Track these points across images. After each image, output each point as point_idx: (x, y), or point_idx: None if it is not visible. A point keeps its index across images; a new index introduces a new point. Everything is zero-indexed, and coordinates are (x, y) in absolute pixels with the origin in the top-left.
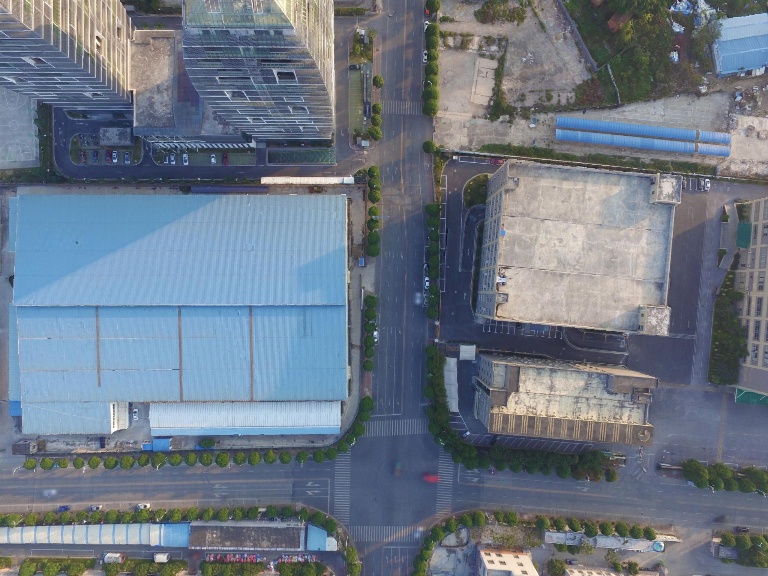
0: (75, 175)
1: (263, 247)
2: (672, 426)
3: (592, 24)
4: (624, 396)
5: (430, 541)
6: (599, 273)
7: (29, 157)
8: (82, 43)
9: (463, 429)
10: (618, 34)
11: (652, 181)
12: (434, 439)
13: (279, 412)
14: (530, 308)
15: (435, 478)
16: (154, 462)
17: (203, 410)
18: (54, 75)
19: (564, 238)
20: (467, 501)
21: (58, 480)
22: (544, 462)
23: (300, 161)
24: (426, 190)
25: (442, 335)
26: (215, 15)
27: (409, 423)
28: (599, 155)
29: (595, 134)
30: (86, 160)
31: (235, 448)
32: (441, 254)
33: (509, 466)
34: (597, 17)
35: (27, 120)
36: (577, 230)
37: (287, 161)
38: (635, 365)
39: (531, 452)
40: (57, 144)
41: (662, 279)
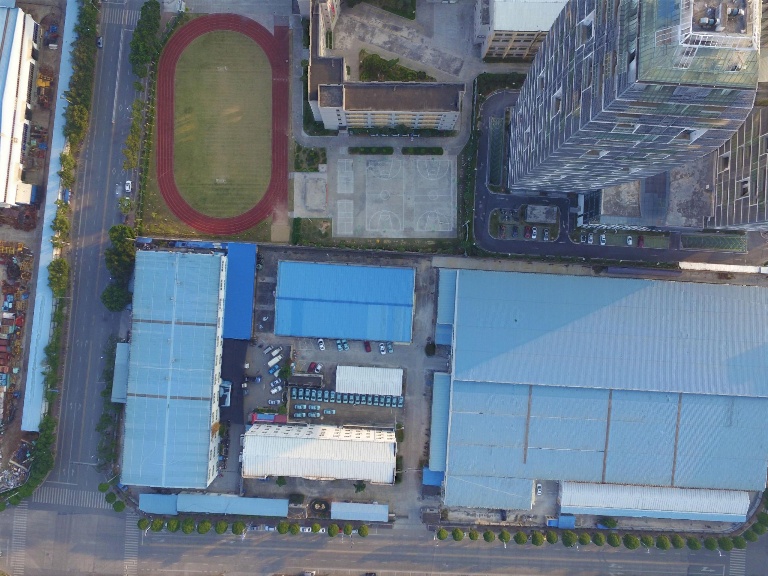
0: (493, 248)
1: (697, 335)
2: None
3: None
4: None
5: None
6: None
7: (447, 228)
8: None
9: None
10: None
11: None
12: None
13: (690, 498)
14: None
15: None
16: (571, 541)
17: (615, 491)
18: None
19: None
20: None
21: (457, 549)
22: None
23: (709, 246)
24: None
25: None
26: None
27: None
28: None
29: None
30: (505, 234)
31: (637, 529)
32: None
33: None
34: None
35: (446, 191)
36: None
37: (694, 245)
38: None
39: None
40: (477, 217)
41: None
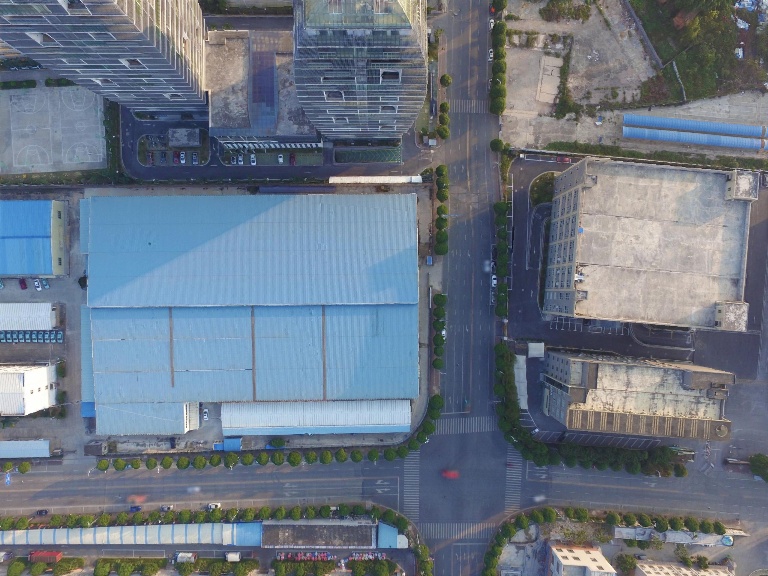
0: (143, 176)
1: (335, 247)
2: (738, 421)
3: (657, 21)
4: (700, 392)
5: (502, 538)
6: (675, 270)
7: (96, 158)
8: (175, 44)
9: (531, 426)
10: (684, 31)
11: (728, 178)
12: (504, 436)
13: (350, 411)
14: (607, 305)
15: (504, 475)
16: (227, 462)
17: (274, 410)
18: (143, 76)
19: (640, 235)
20: (536, 498)
21: (129, 481)
22: (615, 458)
23: (366, 160)
24: (492, 188)
25: (509, 333)
26: (336, 16)
27: (477, 421)
28: (665, 152)
29: (662, 131)
30: (154, 161)
31: (305, 447)
32: (508, 252)
33: (579, 462)
34: (662, 14)
35: (94, 121)
36: (653, 227)
37: (353, 160)
38: (701, 361)
39: (601, 448)
40: (124, 145)
41: (738, 275)
